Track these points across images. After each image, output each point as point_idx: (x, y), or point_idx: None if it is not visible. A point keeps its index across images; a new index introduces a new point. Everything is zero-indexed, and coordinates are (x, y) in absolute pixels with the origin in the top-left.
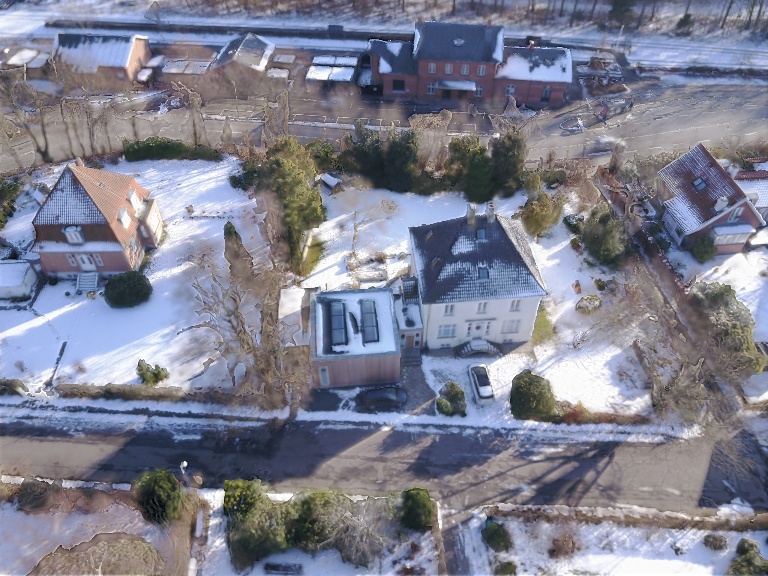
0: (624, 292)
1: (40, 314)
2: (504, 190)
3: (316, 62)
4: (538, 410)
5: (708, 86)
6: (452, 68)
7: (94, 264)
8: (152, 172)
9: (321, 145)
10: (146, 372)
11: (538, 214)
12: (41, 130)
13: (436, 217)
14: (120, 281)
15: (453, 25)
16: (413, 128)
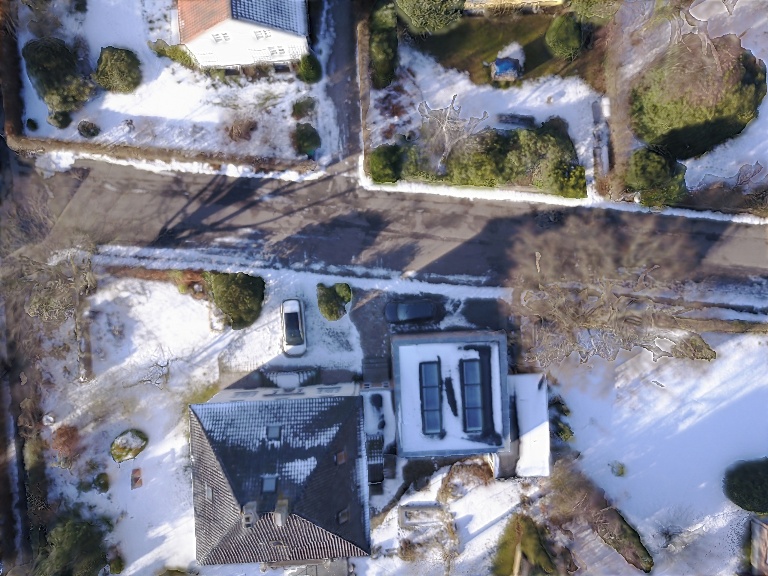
0: (73, 467)
1: None
2: None
3: None
4: None
5: None
6: None
7: None
8: None
9: None
10: (702, 344)
11: None
12: None
13: None
14: None
15: None
16: None
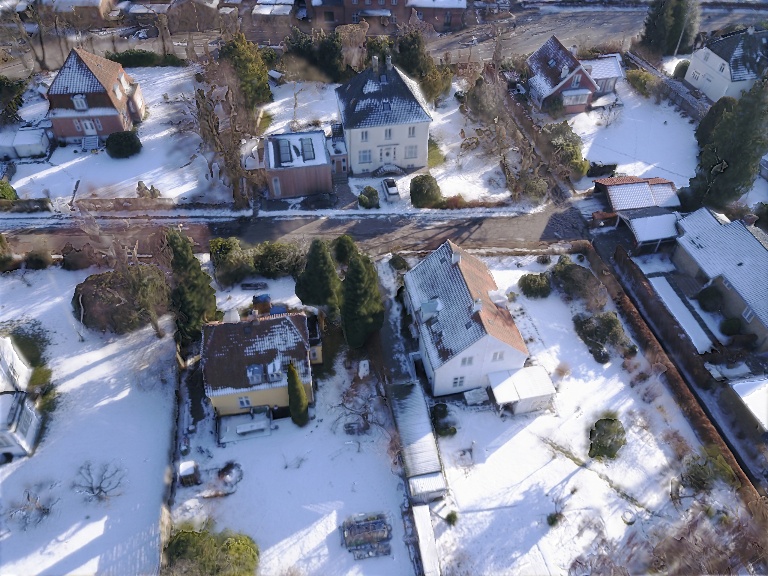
0: None
1: (56, 165)
2: None
3: (260, 2)
4: (429, 198)
5: (576, 13)
6: None
7: (95, 129)
8: (132, 75)
9: (267, 50)
10: (145, 189)
11: (431, 81)
12: (39, 42)
13: None
14: (118, 136)
15: None
16: (338, 31)
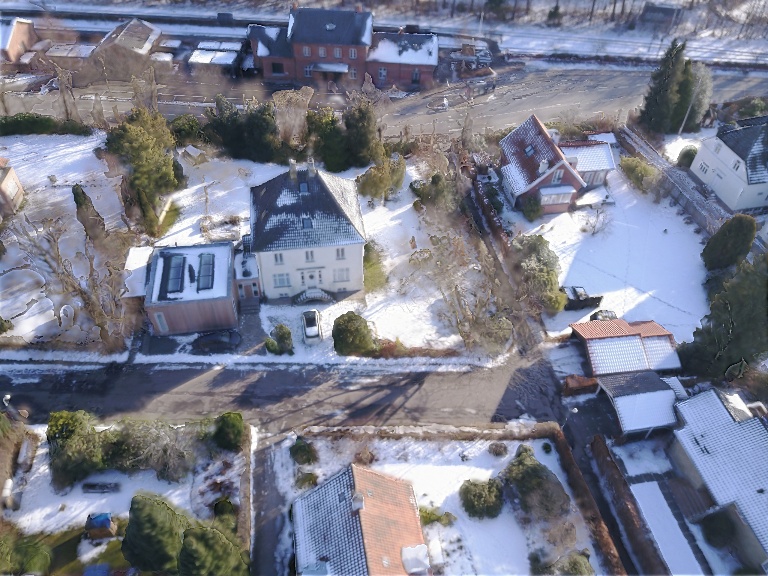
0: None
1: None
2: (360, 160)
3: (201, 47)
4: (357, 346)
5: (567, 71)
6: (326, 51)
7: None
8: (20, 145)
9: (187, 119)
10: None
11: (376, 176)
12: None
13: None
14: None
15: (326, 11)
16: None
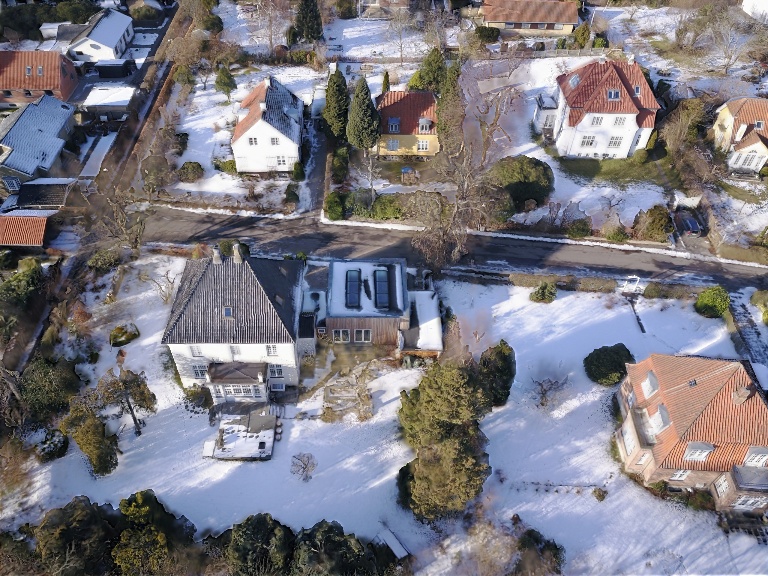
0: None
1: None
2: None
3: None
4: None
5: None
6: None
7: None
8: None
9: None
10: (546, 284)
11: None
12: None
13: (236, 488)
14: (617, 352)
15: None
16: None
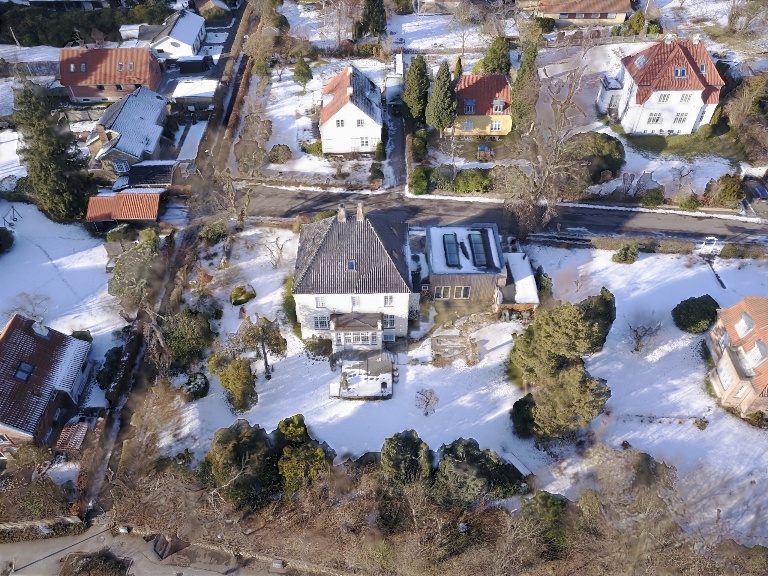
0: None
1: None
2: None
3: None
4: None
5: None
6: None
7: None
8: None
9: (544, 524)
10: (628, 246)
11: None
12: None
13: (363, 422)
14: (705, 301)
15: None
16: None
